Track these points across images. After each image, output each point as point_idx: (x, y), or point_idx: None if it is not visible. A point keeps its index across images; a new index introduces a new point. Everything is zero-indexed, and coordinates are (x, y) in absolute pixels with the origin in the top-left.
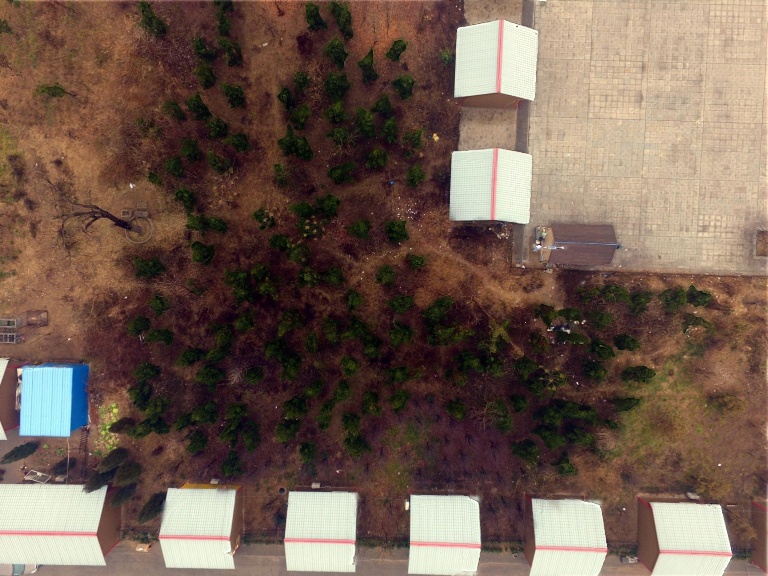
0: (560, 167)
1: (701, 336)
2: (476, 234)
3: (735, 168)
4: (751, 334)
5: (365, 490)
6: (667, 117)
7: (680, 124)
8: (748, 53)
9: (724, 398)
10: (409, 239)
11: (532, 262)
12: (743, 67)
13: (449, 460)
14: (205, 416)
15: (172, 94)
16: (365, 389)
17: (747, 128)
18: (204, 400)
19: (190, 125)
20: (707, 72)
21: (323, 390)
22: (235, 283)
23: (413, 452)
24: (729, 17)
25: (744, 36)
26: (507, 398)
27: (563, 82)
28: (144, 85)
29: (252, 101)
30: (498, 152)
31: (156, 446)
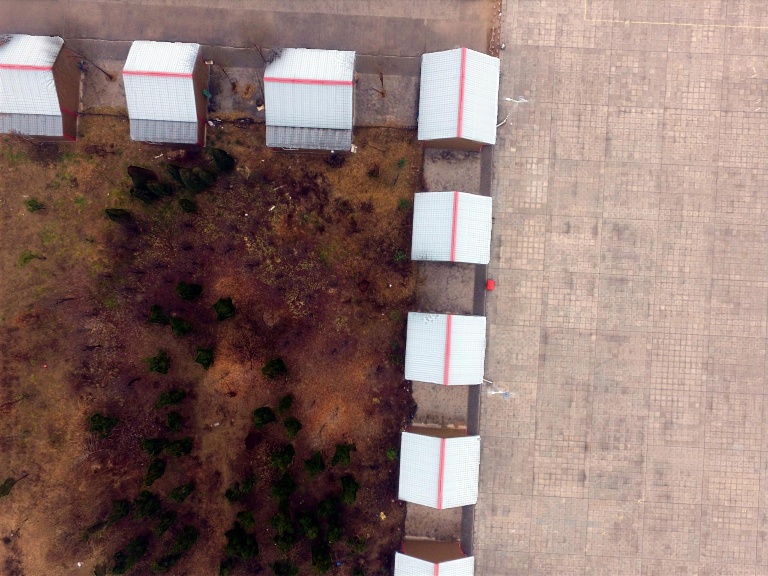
0: (505, 543)
1: None
2: None
3: (676, 548)
4: None
5: None
6: (609, 496)
7: (622, 503)
8: (687, 436)
9: None
10: None
11: None
12: (682, 450)
13: None
14: None
15: (122, 484)
16: None
17: (687, 509)
18: None
19: None
20: (648, 453)
21: None
22: None
23: None
24: (668, 401)
25: (683, 420)
26: None
27: (508, 460)
28: (93, 483)
29: (202, 480)
30: (439, 567)
31: None
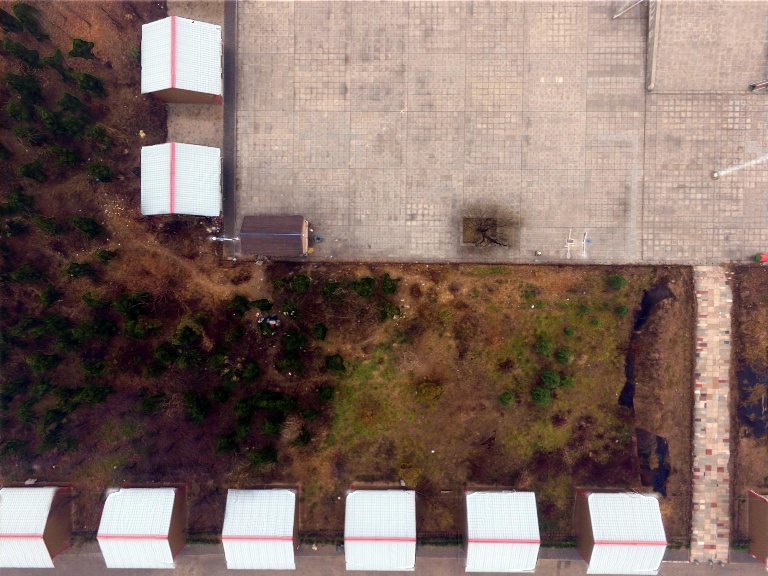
0: (269, 160)
1: (409, 324)
2: (177, 228)
3: (440, 156)
4: (458, 320)
5: (81, 485)
6: (371, 108)
7: (385, 114)
8: (448, 42)
9: None
10: (117, 235)
11: (245, 255)
12: (444, 56)
13: (160, 453)
14: None
15: None
16: (79, 384)
17: (450, 117)
18: None
19: None
20: (409, 62)
21: None
22: None
23: (129, 446)
24: (428, 7)
25: (444, 26)
26: None
27: (268, 76)
28: None
29: None
30: (175, 146)
31: None
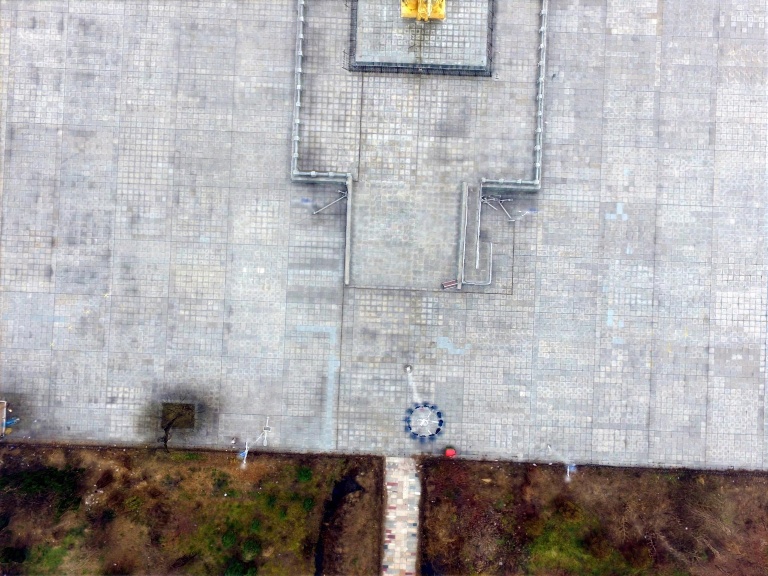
0: None
1: (102, 509)
2: None
3: (142, 341)
4: (151, 507)
5: None
6: (76, 291)
7: (89, 298)
8: (154, 230)
9: None
10: None
11: None
12: (149, 243)
13: None
14: None
15: None
16: None
17: (154, 302)
18: None
19: None
20: (115, 248)
21: None
22: None
23: None
24: (135, 195)
25: (150, 214)
26: None
27: None
28: None
29: None
30: None
31: None
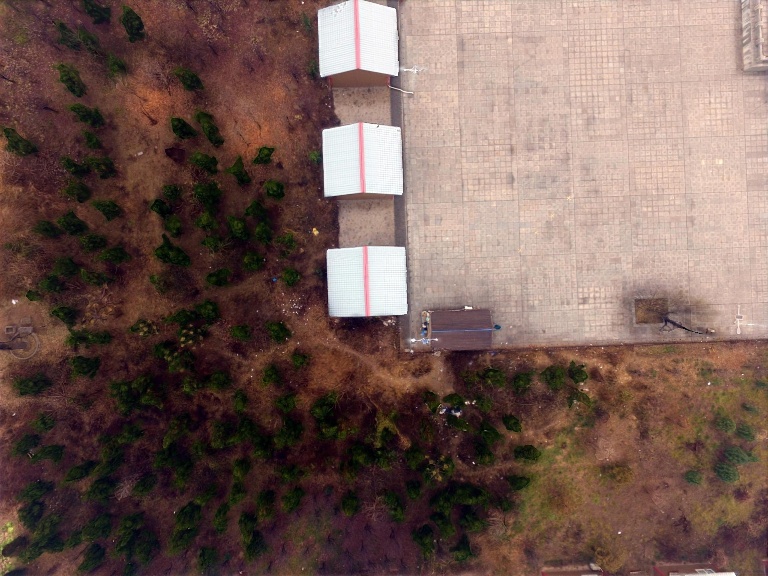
0: (440, 251)
1: (590, 407)
2: (359, 325)
3: (608, 240)
4: (638, 401)
5: None
6: (539, 196)
7: (552, 202)
8: (610, 130)
9: (613, 470)
10: (296, 334)
11: (420, 346)
12: (607, 143)
13: (351, 552)
14: (95, 533)
15: (47, 211)
16: (263, 486)
17: (616, 201)
18: (97, 514)
19: (70, 237)
20: (573, 150)
21: (220, 491)
22: (118, 396)
23: (316, 546)
24: (589, 97)
25: (605, 114)
26: (405, 484)
27: (436, 169)
28: (16, 206)
29: (131, 209)
30: (368, 250)
31: (51, 565)
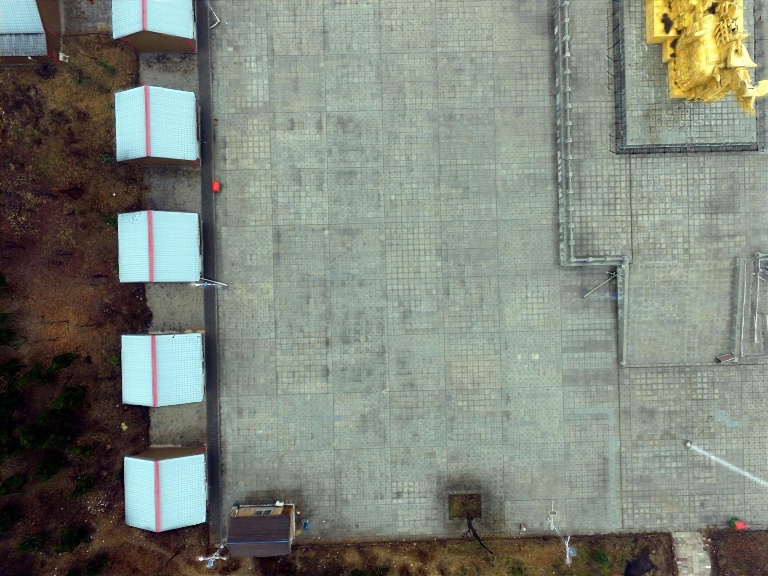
0: (253, 444)
1: None
2: None
3: (423, 434)
4: None
5: None
6: (354, 389)
7: (367, 395)
8: (426, 323)
9: None
10: (101, 532)
11: None
12: (423, 337)
13: None
14: None
15: None
16: None
17: (431, 395)
18: None
19: None
20: (389, 343)
21: None
22: None
23: None
24: (405, 290)
25: (421, 307)
26: None
27: (250, 361)
28: None
29: None
30: (159, 464)
31: None
